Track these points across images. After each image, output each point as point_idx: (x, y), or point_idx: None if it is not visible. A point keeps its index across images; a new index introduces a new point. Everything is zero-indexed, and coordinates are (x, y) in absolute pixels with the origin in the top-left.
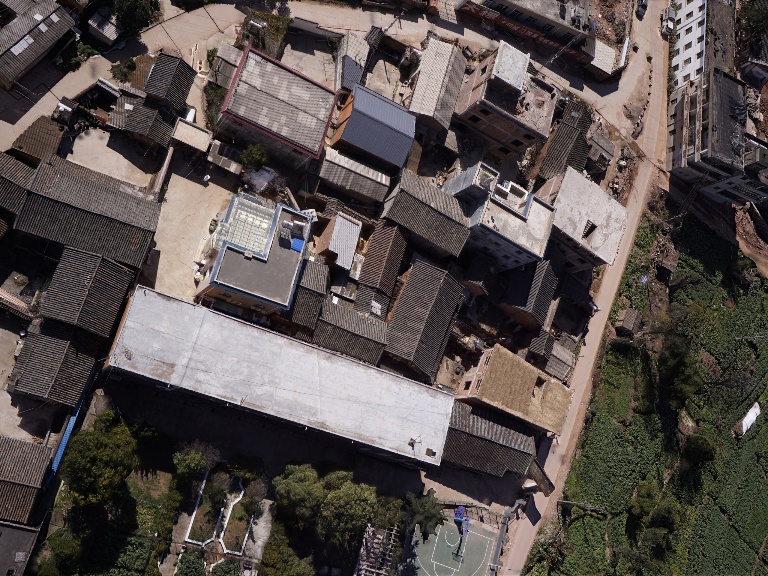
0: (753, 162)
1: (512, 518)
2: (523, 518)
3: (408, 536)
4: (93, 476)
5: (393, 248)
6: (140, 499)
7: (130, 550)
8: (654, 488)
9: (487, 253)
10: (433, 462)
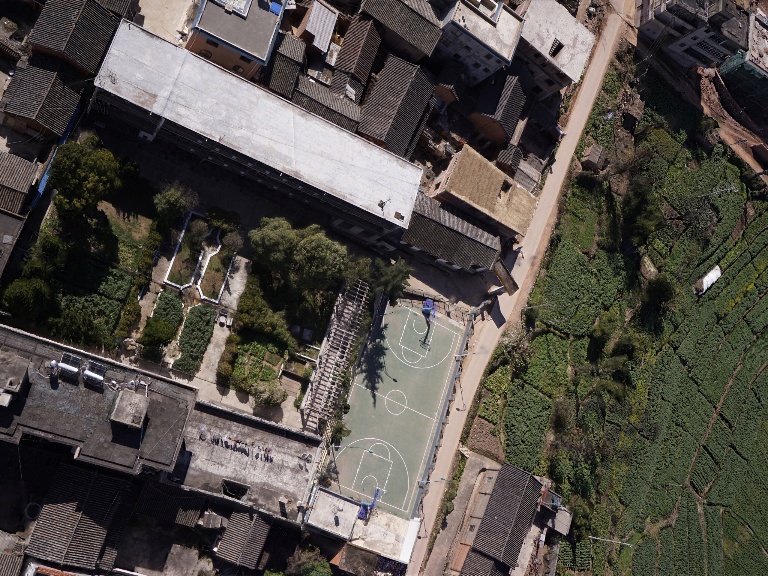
0: (716, 13)
1: (477, 314)
2: (488, 320)
3: (378, 319)
4: (78, 178)
5: (368, 40)
6: (122, 237)
7: (111, 281)
8: (615, 314)
9: (458, 62)
10: (401, 225)
